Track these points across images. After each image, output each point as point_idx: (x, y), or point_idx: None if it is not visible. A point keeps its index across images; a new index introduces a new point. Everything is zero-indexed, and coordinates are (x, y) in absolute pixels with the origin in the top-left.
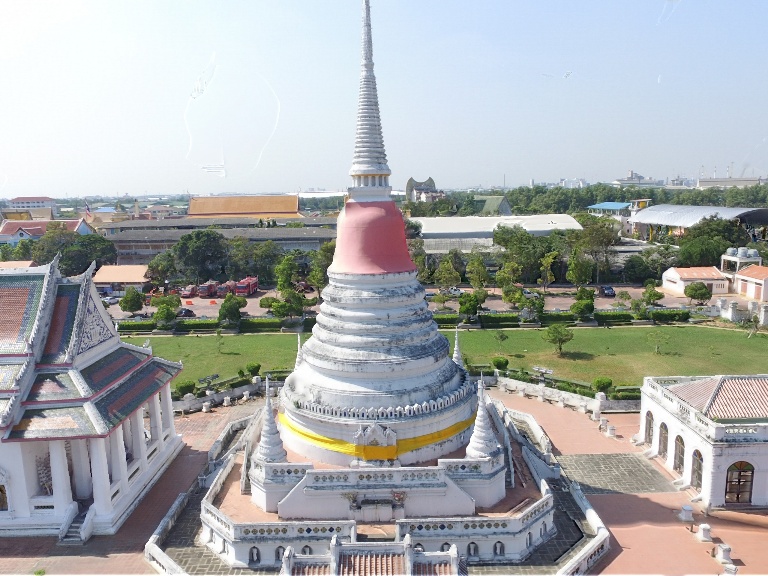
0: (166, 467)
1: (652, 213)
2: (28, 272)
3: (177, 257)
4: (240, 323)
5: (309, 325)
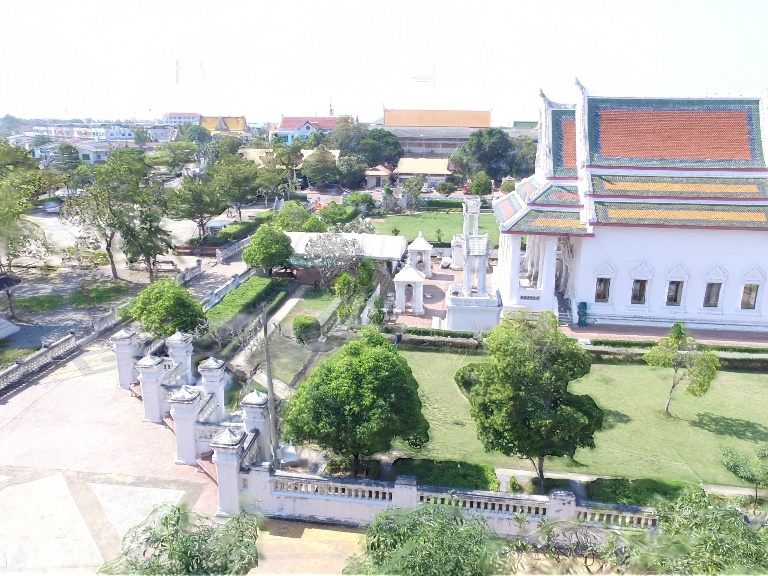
0: None
1: None
2: (742, 96)
3: (471, 153)
4: None
5: None
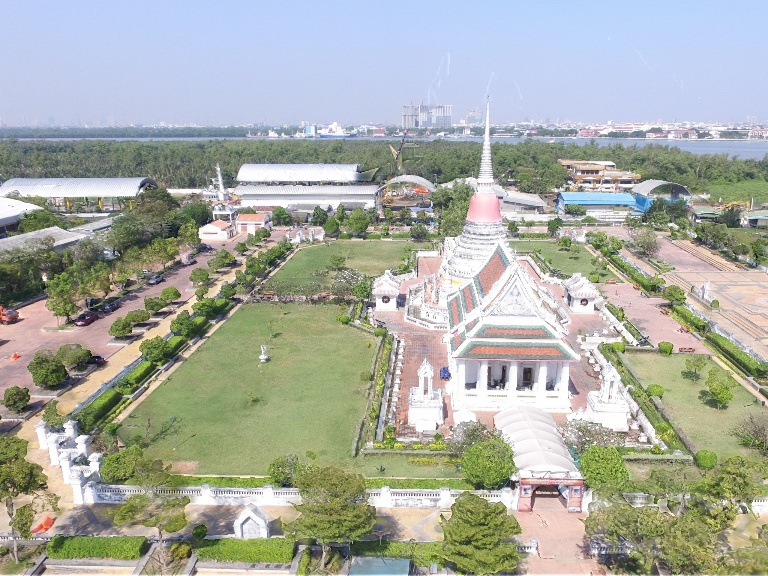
0: None
1: (26, 188)
2: None
3: None
4: (192, 330)
5: (216, 312)
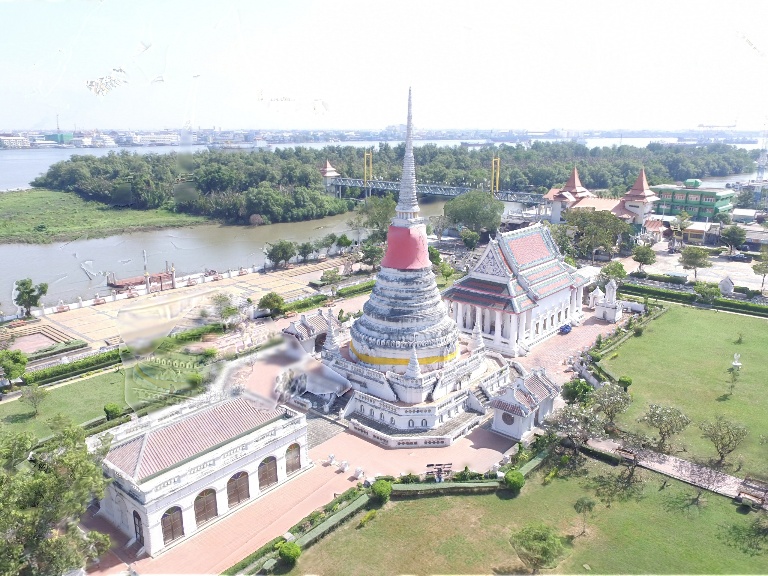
0: (488, 349)
1: None
2: None
3: None
4: None
5: None
